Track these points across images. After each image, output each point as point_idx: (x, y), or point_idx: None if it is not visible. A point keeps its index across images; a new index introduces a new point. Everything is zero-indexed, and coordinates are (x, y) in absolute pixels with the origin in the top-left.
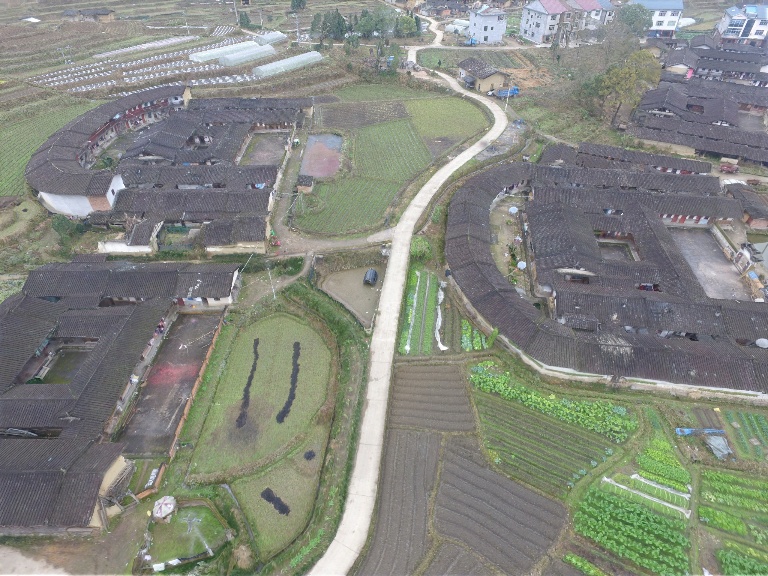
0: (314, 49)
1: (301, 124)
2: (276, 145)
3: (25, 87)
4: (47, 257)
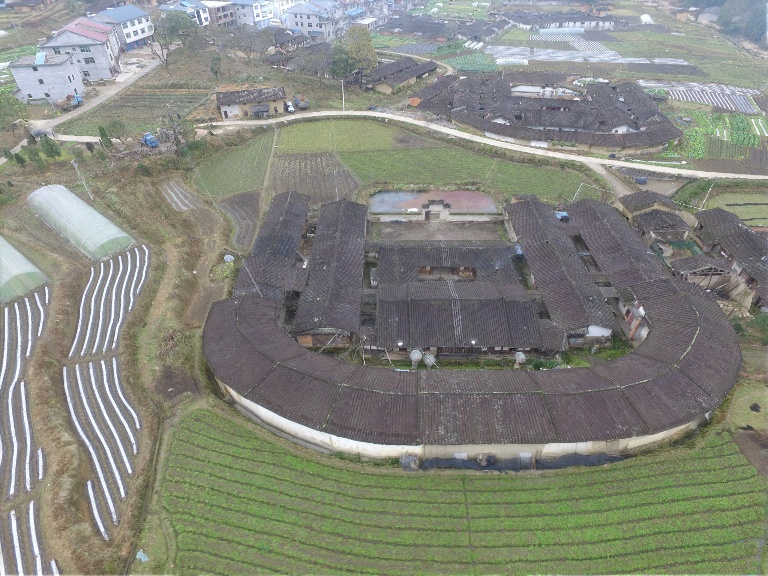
0: None
1: None
2: (411, 231)
3: None
4: None
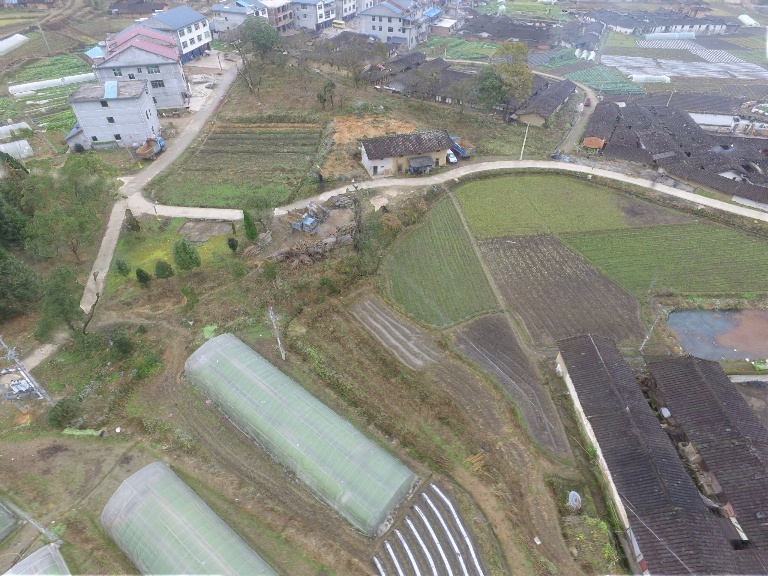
0: (123, 361)
1: None
2: None
3: None
4: None
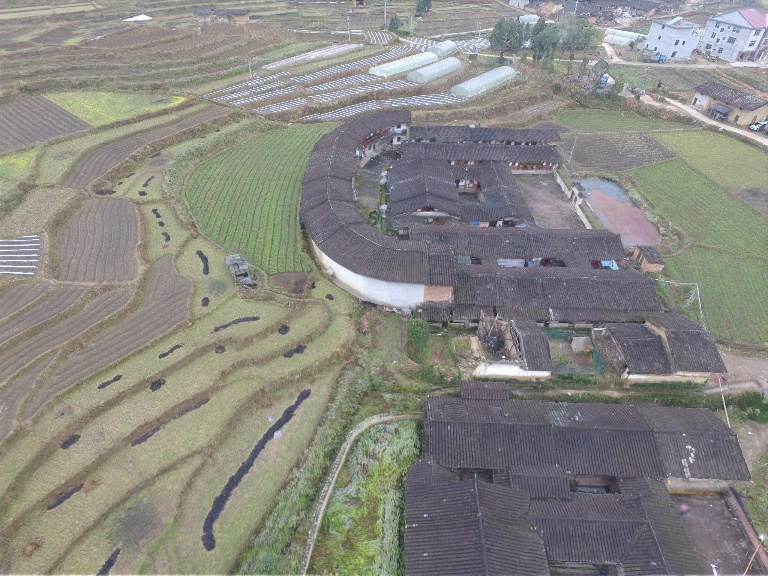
0: (496, 63)
1: (561, 164)
2: (547, 193)
3: (209, 106)
4: (404, 380)
